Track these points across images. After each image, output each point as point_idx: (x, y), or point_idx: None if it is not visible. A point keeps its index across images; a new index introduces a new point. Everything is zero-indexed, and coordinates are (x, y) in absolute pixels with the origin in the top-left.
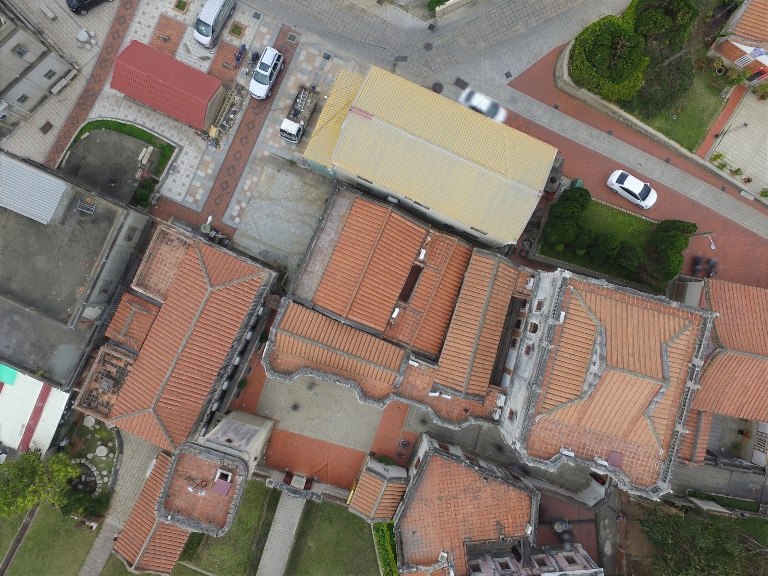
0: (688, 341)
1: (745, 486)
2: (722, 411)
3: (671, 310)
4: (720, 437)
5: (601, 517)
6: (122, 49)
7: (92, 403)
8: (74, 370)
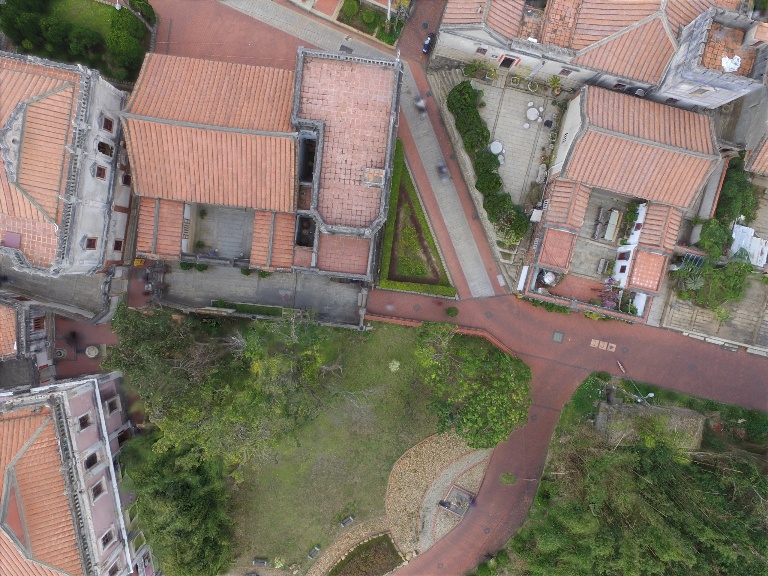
0: (72, 105)
1: (275, 293)
2: (176, 196)
3: (52, 72)
4: (241, 243)
5: None
6: None
7: None
8: None
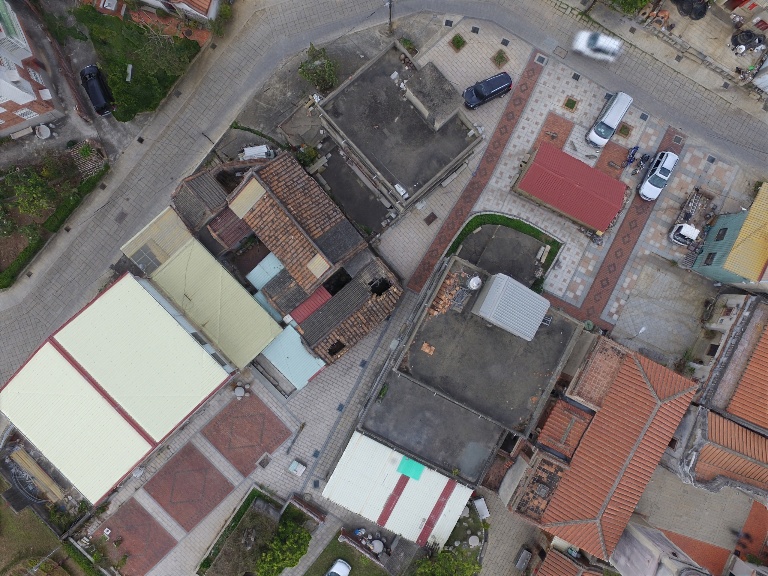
0: None
1: None
2: None
3: None
4: None
5: None
6: (509, 144)
7: (522, 507)
8: None
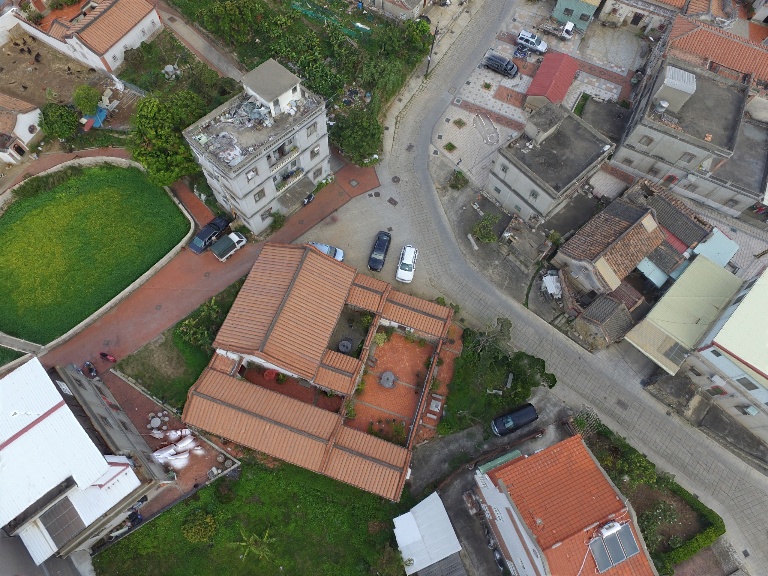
0: None
1: None
2: None
3: None
4: None
5: None
6: (519, 121)
7: None
8: (762, 123)
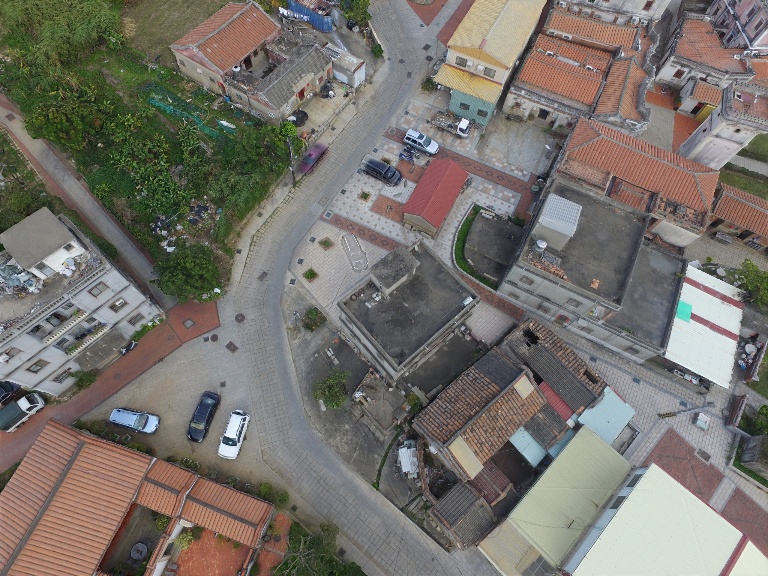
0: None
1: None
2: None
3: None
4: None
5: (683, 7)
6: (396, 239)
7: (697, 225)
8: (670, 251)
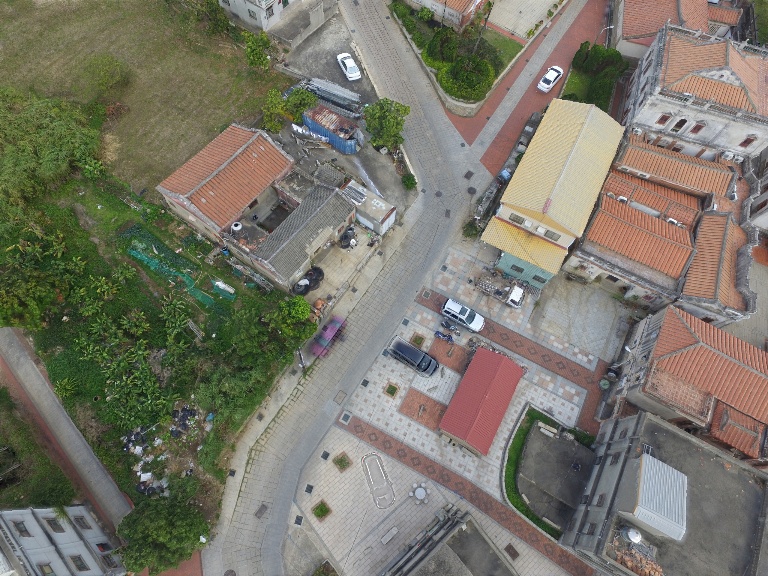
0: None
1: None
2: None
3: None
4: None
5: None
6: (430, 456)
7: None
8: None
